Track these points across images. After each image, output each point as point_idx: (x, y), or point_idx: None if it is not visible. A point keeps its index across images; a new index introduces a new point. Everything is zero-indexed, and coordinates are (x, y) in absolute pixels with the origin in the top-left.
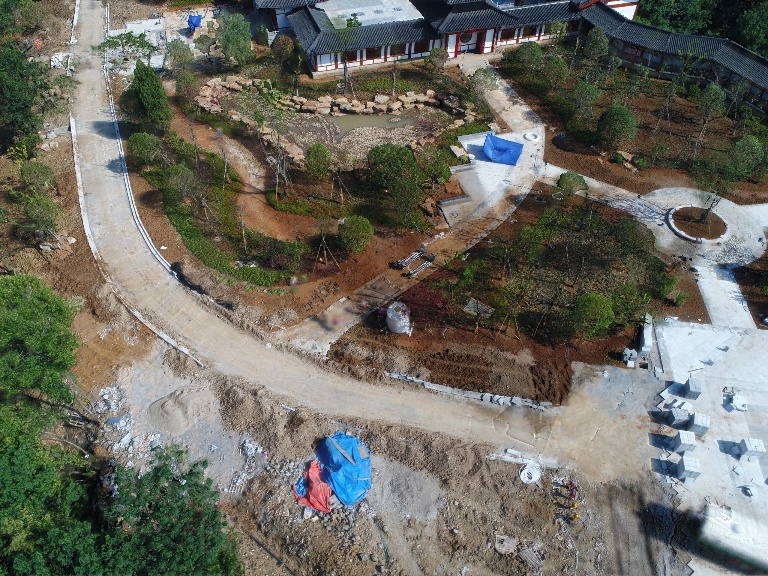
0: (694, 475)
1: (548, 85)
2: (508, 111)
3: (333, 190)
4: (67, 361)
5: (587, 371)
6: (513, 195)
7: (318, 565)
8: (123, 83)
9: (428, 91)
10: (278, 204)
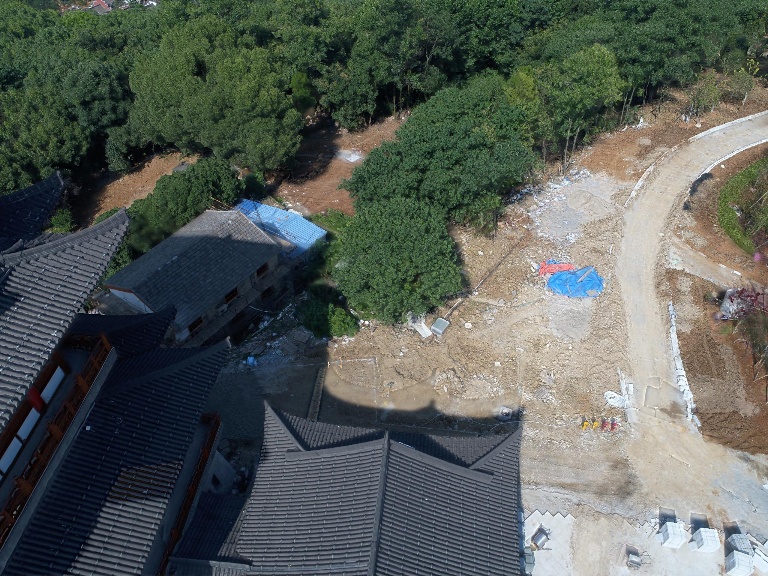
0: (666, 536)
1: None
2: None
3: None
4: (573, 100)
5: (762, 468)
6: None
7: None
8: None
9: None
10: None
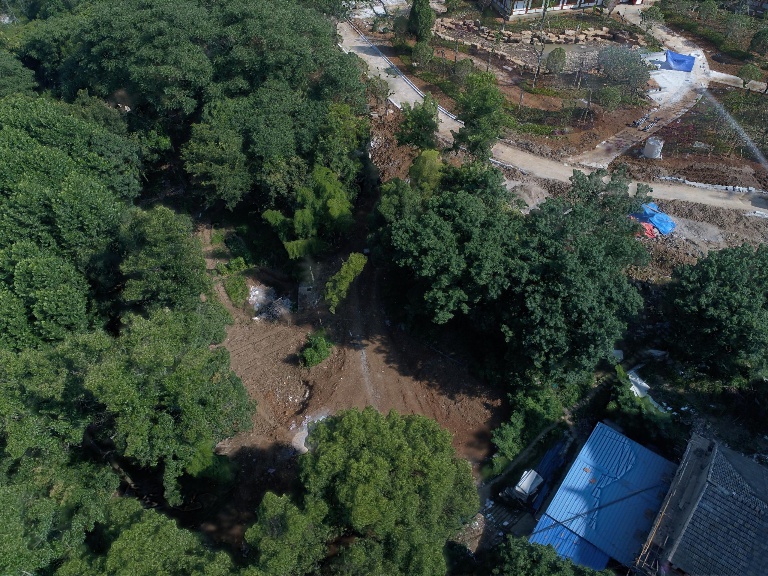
0: None
1: (696, 24)
2: (670, 41)
3: (565, 84)
4: None
5: None
6: (697, 88)
7: (661, 258)
8: (363, 23)
9: (603, 28)
10: (533, 89)
